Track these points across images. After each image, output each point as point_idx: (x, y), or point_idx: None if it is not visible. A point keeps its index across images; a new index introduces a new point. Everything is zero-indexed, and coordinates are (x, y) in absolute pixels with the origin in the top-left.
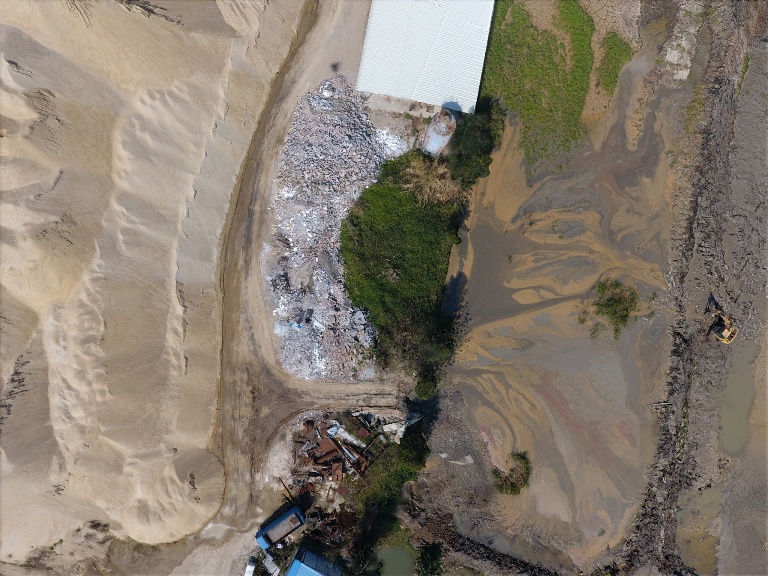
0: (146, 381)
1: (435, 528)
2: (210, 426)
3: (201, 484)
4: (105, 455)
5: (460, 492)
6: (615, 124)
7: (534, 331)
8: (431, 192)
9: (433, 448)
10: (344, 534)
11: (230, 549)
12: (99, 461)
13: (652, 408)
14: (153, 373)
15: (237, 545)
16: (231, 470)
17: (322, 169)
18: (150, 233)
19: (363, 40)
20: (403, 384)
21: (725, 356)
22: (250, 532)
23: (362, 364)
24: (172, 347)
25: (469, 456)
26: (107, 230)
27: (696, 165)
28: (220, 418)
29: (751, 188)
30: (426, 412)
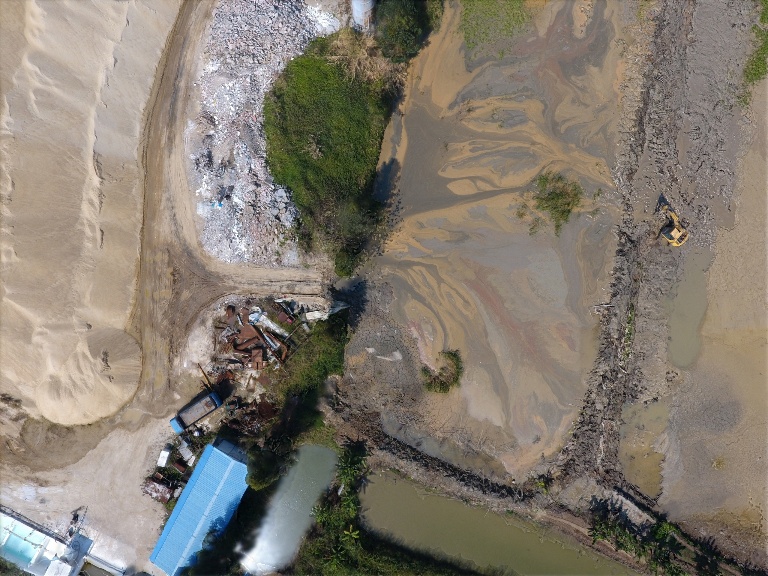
0: (57, 249)
1: (359, 425)
2: (128, 306)
3: (115, 363)
4: (11, 321)
5: (388, 390)
6: (562, 9)
7: (469, 223)
8: (360, 68)
9: (360, 341)
10: (263, 424)
11: (146, 435)
12: (5, 326)
13: (594, 310)
14: (65, 242)
15: (153, 431)
16: (149, 353)
17: (246, 40)
18: (66, 97)
19: None
20: (328, 270)
21: (677, 262)
22: (167, 418)
23: (284, 246)
24: (87, 218)
25: (397, 352)
26: (19, 88)
27: (648, 54)
28: (139, 299)
29: (709, 84)
30: (352, 302)
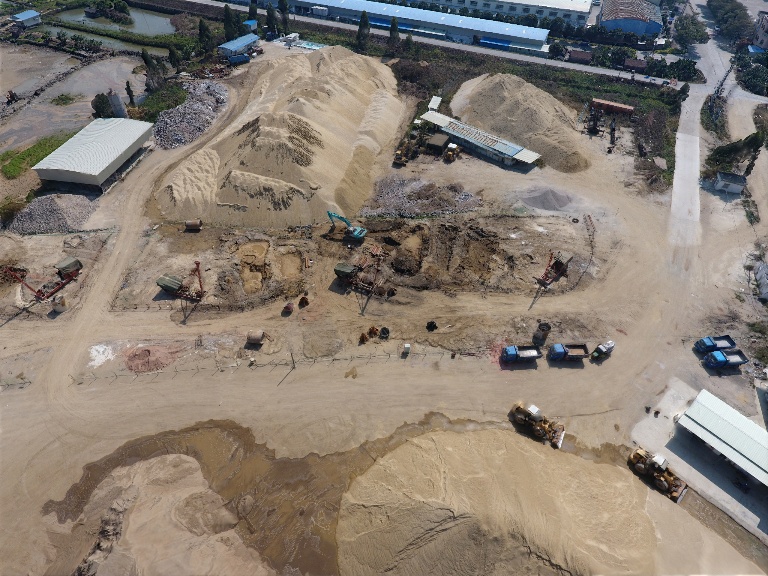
0: None
1: None
2: None
3: None
4: None
5: None
6: (18, 143)
7: None
8: None
9: None
10: None
11: None
12: None
13: None
14: None
15: (259, 60)
16: (257, 71)
17: None
18: None
19: (146, 160)
20: None
21: None
22: None
23: None
24: None
25: None
26: None
27: None
28: None
29: None
30: None
